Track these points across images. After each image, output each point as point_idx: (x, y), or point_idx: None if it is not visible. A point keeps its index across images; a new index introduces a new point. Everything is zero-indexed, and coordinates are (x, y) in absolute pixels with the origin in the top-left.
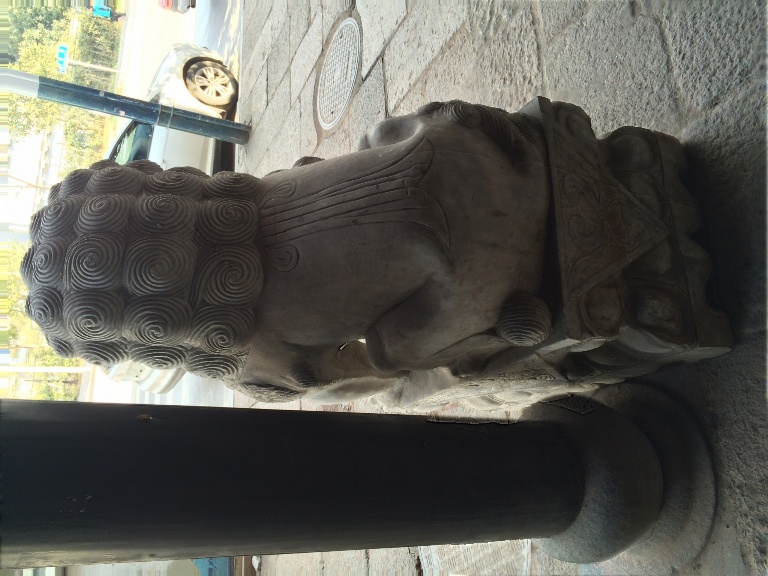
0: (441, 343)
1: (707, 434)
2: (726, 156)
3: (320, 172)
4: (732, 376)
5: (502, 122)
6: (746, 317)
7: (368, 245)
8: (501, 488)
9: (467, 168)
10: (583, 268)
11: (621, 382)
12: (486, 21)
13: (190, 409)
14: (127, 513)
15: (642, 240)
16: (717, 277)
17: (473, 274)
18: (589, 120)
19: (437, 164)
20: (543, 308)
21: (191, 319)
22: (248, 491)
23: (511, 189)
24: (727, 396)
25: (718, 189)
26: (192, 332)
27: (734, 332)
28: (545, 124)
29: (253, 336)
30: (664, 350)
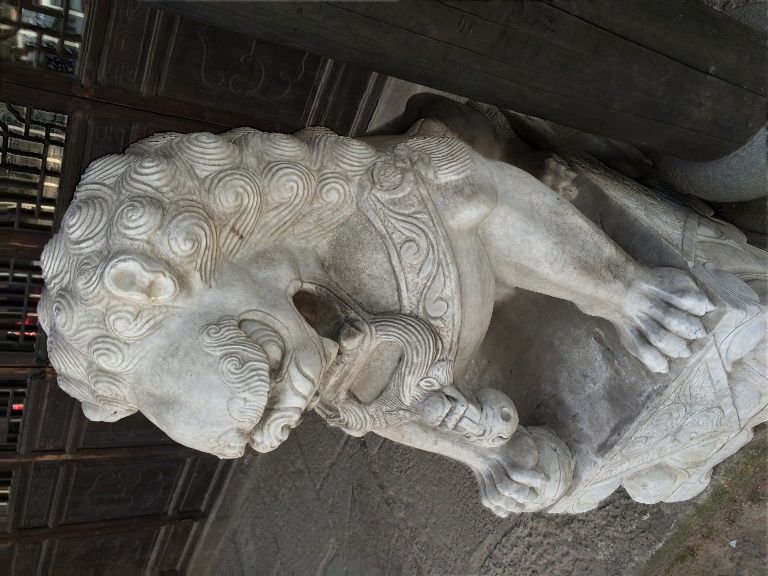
0: None
1: None
2: None
3: None
4: None
5: None
6: None
7: None
8: None
9: None
10: None
11: (709, 206)
12: None
13: None
14: None
15: None
16: None
17: None
18: None
19: None
20: None
21: None
22: None
23: None
24: None
25: None
26: None
27: None
28: None
29: None
30: (593, 136)
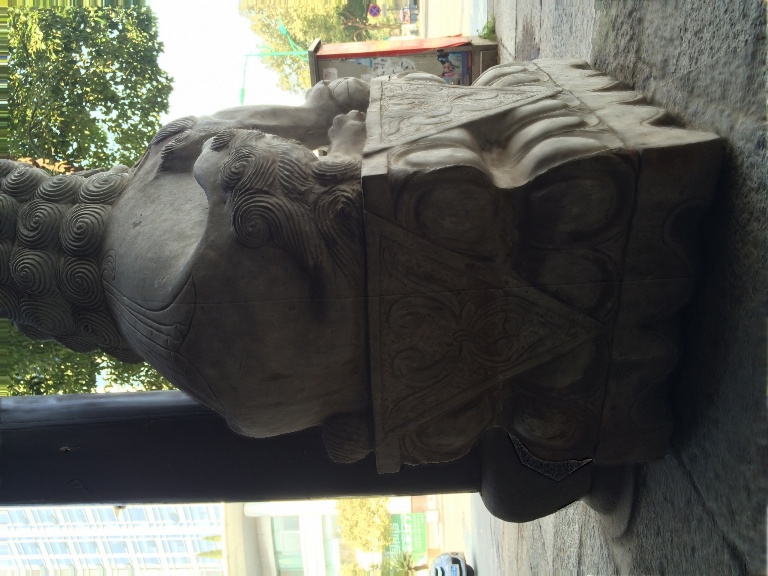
0: None
1: (638, 480)
2: (748, 238)
3: (124, 268)
4: (661, 471)
5: (296, 238)
6: (687, 444)
7: None
8: (381, 484)
9: (234, 329)
10: (411, 406)
11: None
12: None
13: (106, 426)
14: (86, 483)
15: (535, 351)
16: (680, 377)
17: (260, 424)
18: (479, 176)
19: (196, 328)
20: (358, 438)
21: (96, 346)
22: (152, 488)
23: (296, 345)
24: (654, 479)
25: (726, 271)
26: None
27: (674, 443)
28: (367, 231)
29: None
30: None
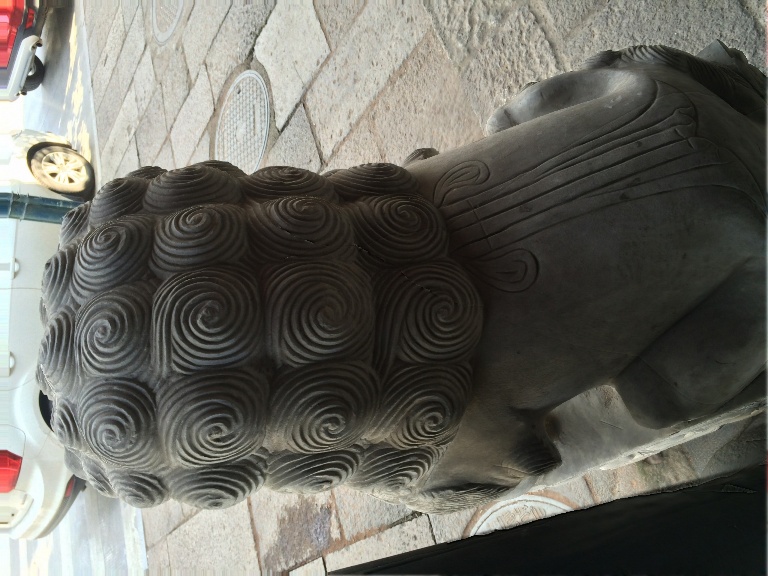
0: (759, 366)
1: None
2: None
3: (519, 141)
4: None
5: (710, 65)
6: None
7: (654, 229)
8: None
9: (730, 113)
10: None
11: None
12: (466, 32)
13: (458, 552)
14: None
15: None
16: None
17: None
18: None
19: (702, 107)
20: None
21: (380, 394)
22: None
23: None
24: None
25: None
26: (382, 416)
27: None
28: (744, 70)
29: (468, 407)
30: None
